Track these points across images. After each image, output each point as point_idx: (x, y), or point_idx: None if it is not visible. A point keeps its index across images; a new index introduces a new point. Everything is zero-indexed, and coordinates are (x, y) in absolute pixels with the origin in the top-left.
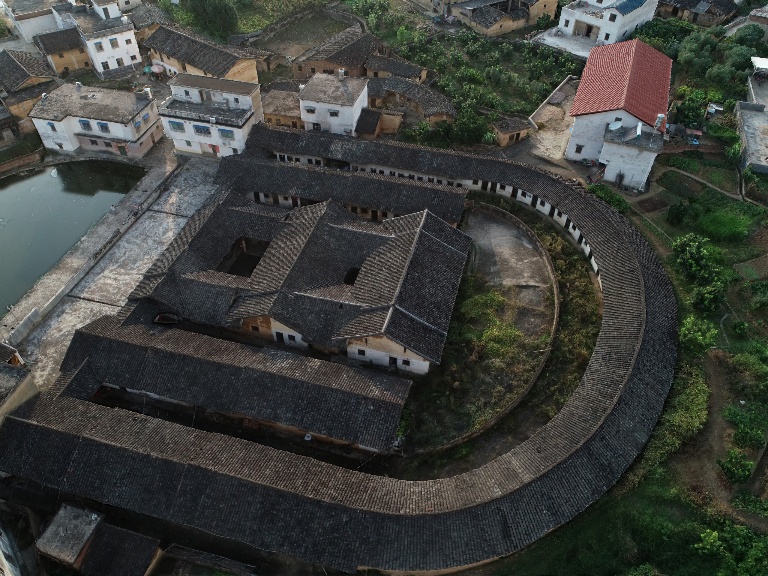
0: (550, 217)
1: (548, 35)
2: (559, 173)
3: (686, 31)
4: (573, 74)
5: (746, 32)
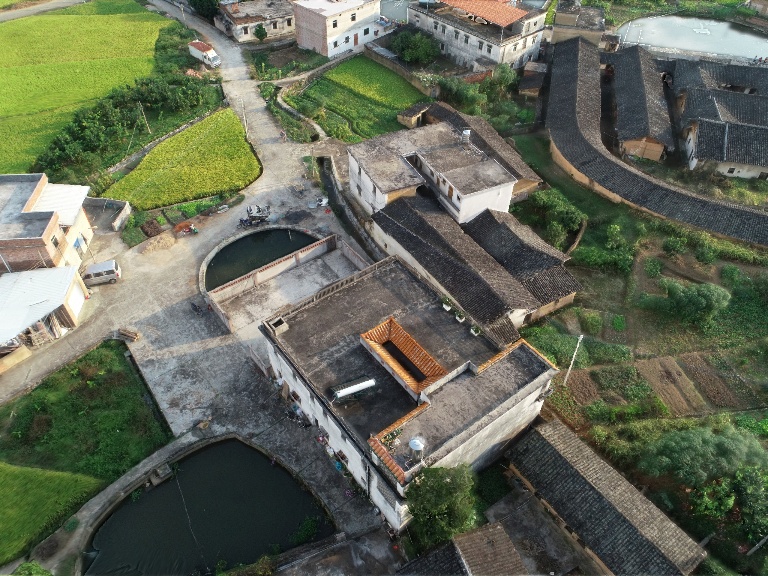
0: None
1: None
2: None
3: None
4: None
5: None
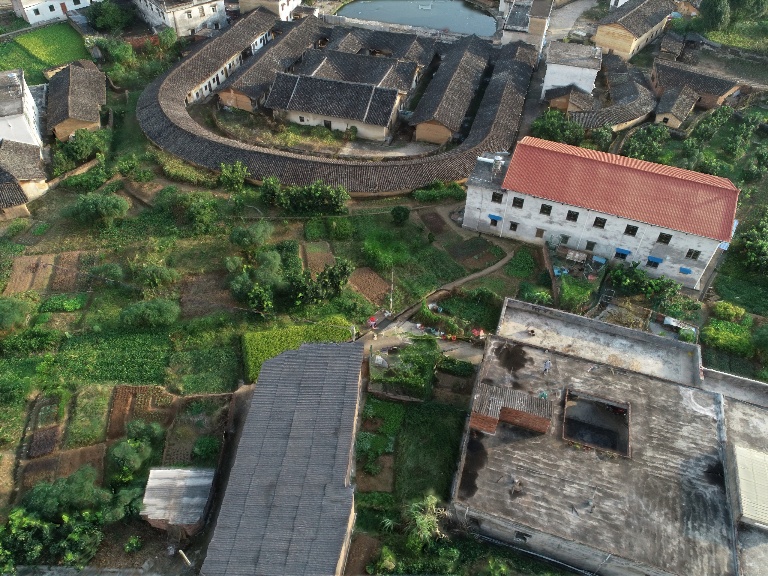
0: None
1: None
2: None
3: None
4: None
5: None
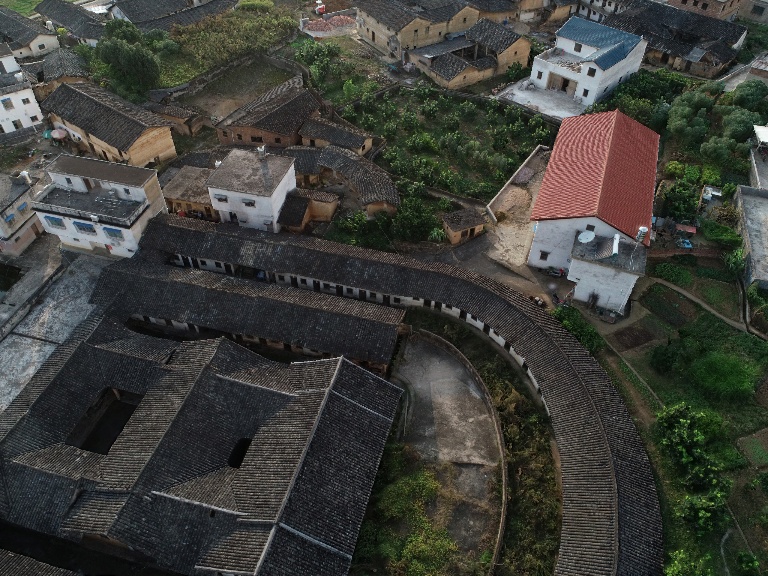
0: (506, 350)
1: (518, 89)
2: (519, 286)
3: (677, 85)
4: (545, 141)
5: (747, 90)
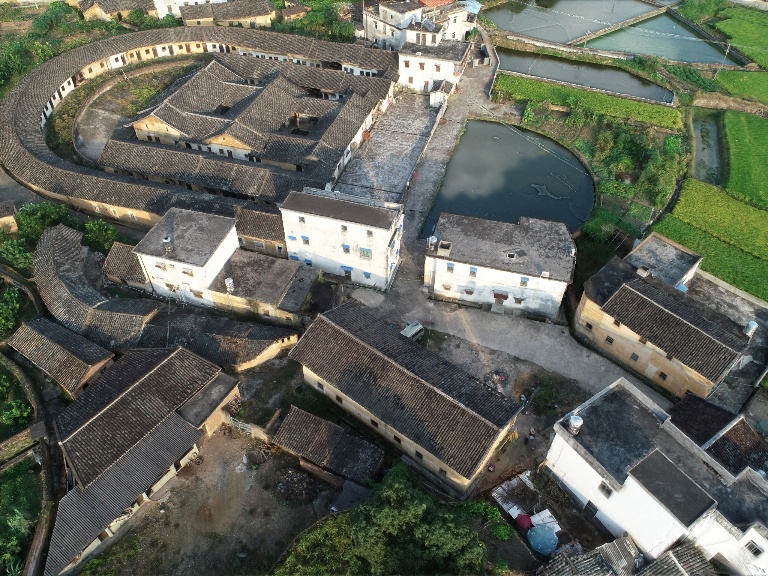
0: None
1: None
2: None
3: None
4: None
5: None
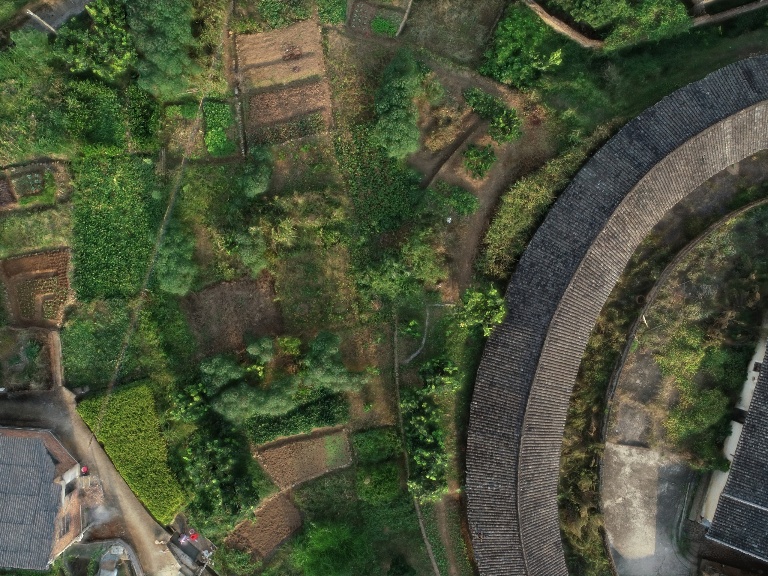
0: None
1: None
2: None
3: None
4: None
5: None
